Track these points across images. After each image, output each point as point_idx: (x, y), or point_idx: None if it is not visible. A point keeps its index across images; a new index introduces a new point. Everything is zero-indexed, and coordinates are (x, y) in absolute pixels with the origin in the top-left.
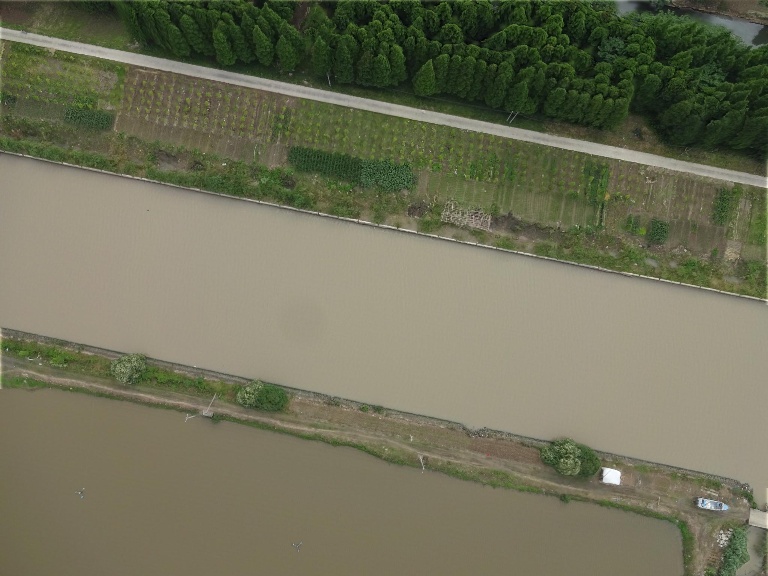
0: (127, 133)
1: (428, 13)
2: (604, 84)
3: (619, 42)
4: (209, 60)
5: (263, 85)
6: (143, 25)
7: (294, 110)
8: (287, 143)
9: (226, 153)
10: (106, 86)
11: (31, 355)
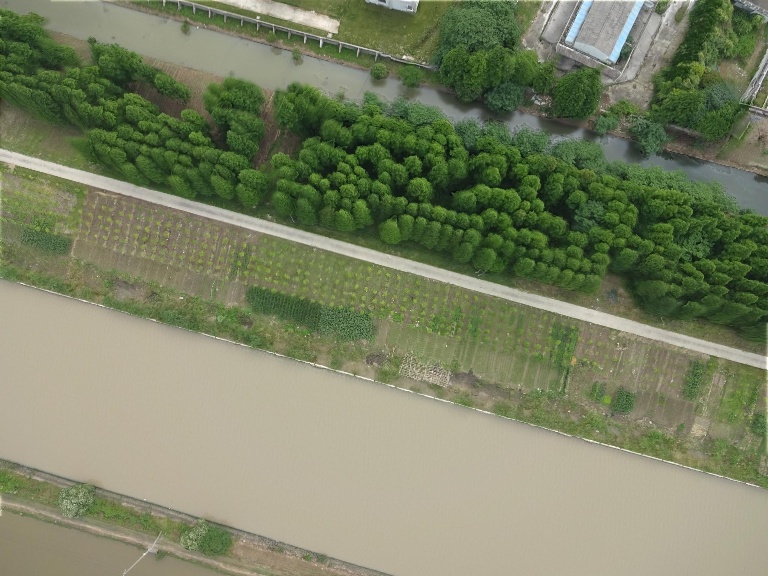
0: (84, 259)
1: (395, 169)
2: (575, 260)
3: (598, 208)
4: (170, 188)
5: (225, 217)
6: (100, 157)
7: (255, 247)
8: (246, 281)
9: (183, 287)
10: (65, 208)
11: None
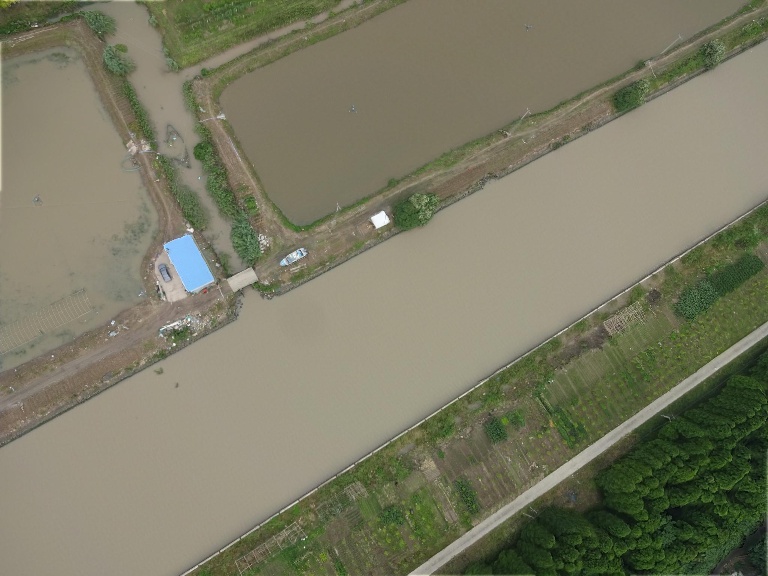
0: None
1: None
2: None
3: None
4: None
5: None
6: None
7: None
8: (767, 267)
9: None
10: None
11: (764, 21)
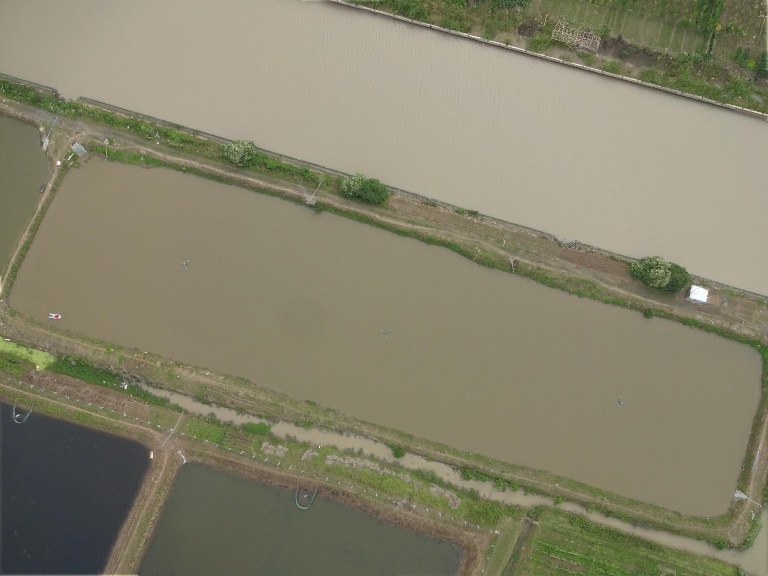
0: None
1: None
2: None
3: None
4: None
5: None
6: None
7: None
8: None
9: None
10: None
11: (150, 133)
